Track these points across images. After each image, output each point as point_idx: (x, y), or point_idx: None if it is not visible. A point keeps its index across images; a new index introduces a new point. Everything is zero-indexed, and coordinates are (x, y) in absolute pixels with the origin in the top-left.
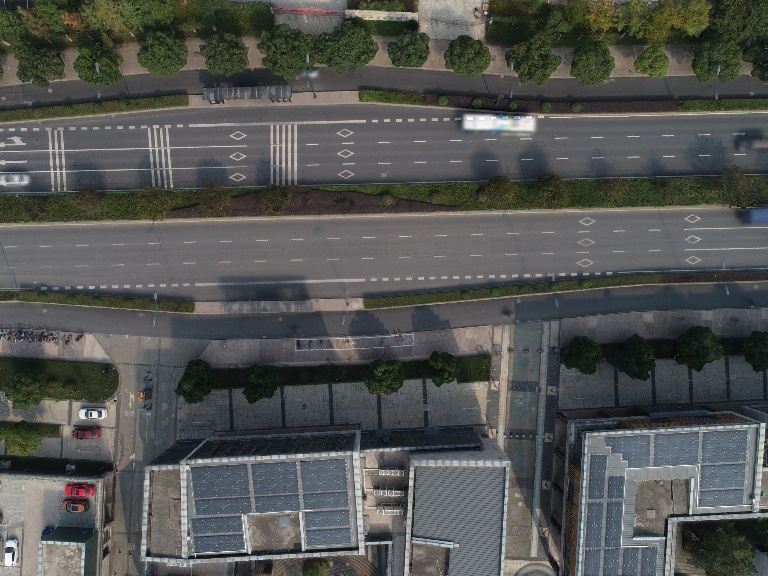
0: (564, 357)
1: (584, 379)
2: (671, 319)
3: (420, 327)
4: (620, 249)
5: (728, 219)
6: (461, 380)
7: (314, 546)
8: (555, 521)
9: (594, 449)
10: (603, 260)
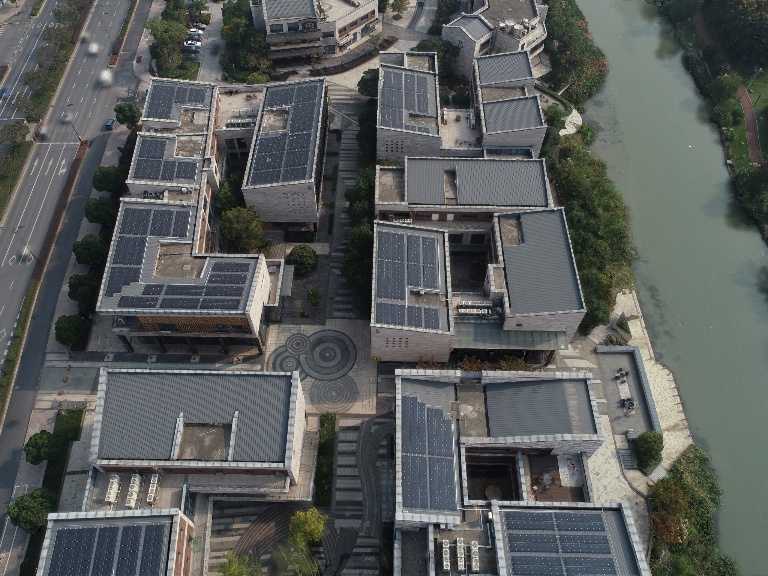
0: (65, 343)
1: (106, 332)
2: (73, 272)
3: (11, 480)
4: (0, 309)
5: (5, 239)
6: (75, 436)
7: (161, 568)
8: (223, 349)
9: (113, 305)
10: (5, 322)
